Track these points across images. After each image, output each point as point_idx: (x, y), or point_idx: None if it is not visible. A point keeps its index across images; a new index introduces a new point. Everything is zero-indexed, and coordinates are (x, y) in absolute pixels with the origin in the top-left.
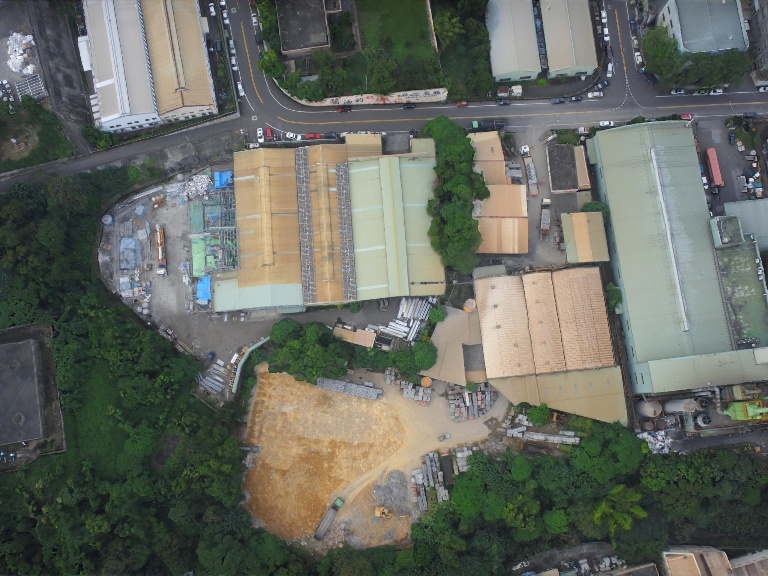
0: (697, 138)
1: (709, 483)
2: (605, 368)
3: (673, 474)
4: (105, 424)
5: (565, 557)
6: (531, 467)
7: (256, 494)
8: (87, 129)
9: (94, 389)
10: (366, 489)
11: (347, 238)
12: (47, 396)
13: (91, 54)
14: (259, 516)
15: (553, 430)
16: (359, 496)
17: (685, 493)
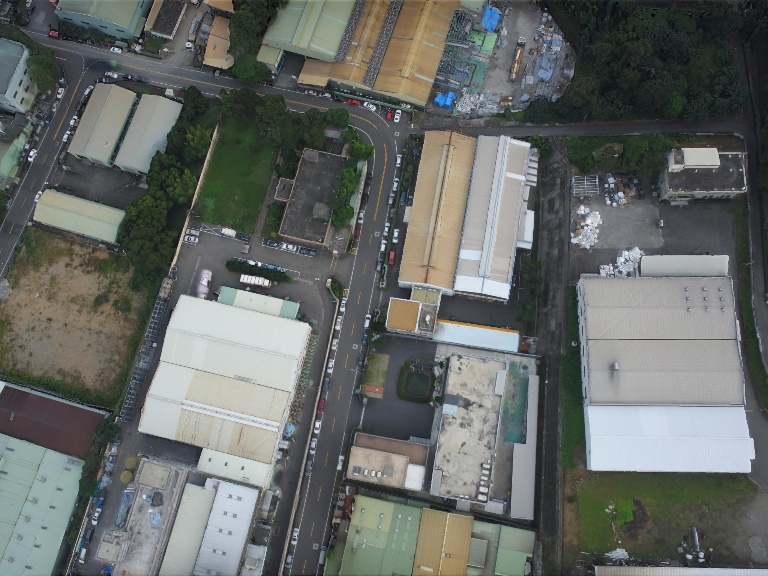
0: None
1: None
2: None
3: None
4: None
5: None
6: None
7: None
8: (546, 147)
9: None
10: None
11: (360, 4)
12: None
13: None
14: None
15: None
16: None
17: None
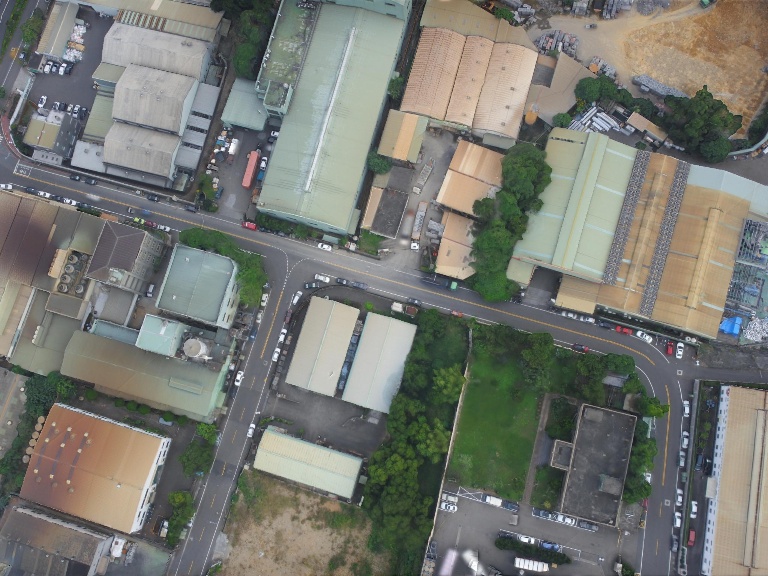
0: (249, 205)
1: None
2: None
3: None
4: None
5: None
6: None
7: None
8: None
9: None
10: (676, 8)
11: (628, 209)
12: None
13: None
14: None
15: (494, 3)
16: (684, 5)
17: None
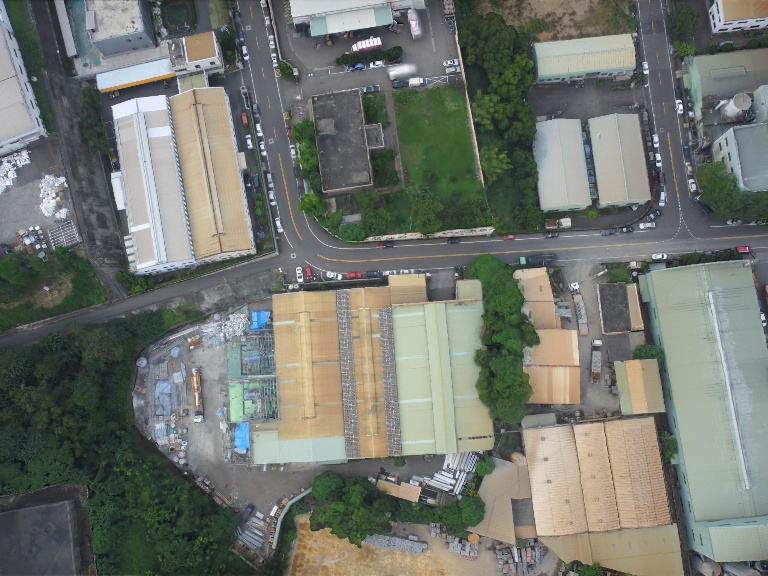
0: (754, 271)
1: None
2: (661, 525)
3: None
4: None
5: None
6: None
7: None
8: (122, 275)
9: (131, 551)
10: None
11: (391, 388)
12: (83, 559)
13: (125, 195)
14: None
15: None
16: None
17: None
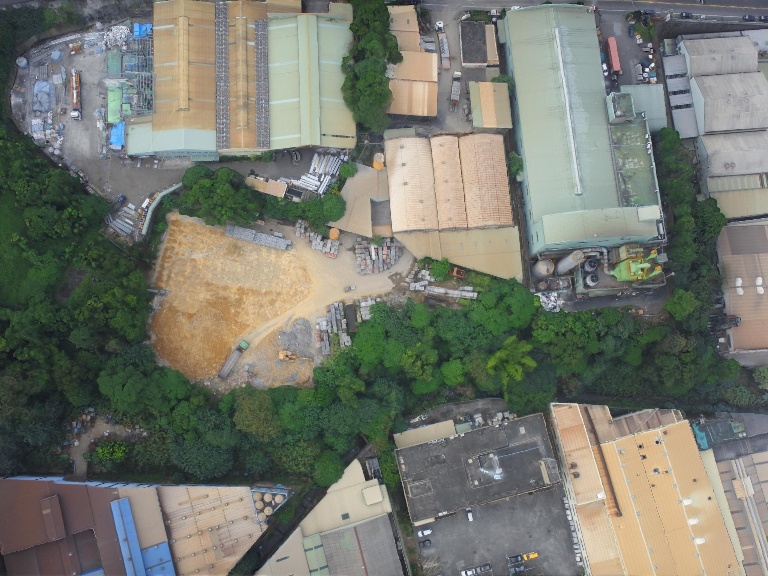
0: (600, 29)
1: (595, 338)
2: (504, 228)
3: (561, 326)
4: (9, 252)
5: (461, 412)
6: (430, 316)
7: (162, 335)
8: None
9: None
10: (271, 334)
11: (263, 90)
12: None
13: None
14: (164, 356)
15: (453, 286)
16: (264, 341)
17: (572, 344)
